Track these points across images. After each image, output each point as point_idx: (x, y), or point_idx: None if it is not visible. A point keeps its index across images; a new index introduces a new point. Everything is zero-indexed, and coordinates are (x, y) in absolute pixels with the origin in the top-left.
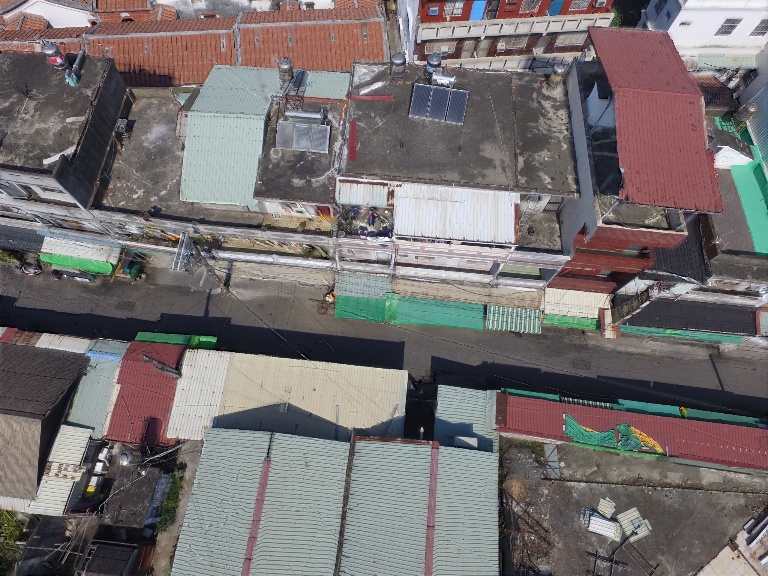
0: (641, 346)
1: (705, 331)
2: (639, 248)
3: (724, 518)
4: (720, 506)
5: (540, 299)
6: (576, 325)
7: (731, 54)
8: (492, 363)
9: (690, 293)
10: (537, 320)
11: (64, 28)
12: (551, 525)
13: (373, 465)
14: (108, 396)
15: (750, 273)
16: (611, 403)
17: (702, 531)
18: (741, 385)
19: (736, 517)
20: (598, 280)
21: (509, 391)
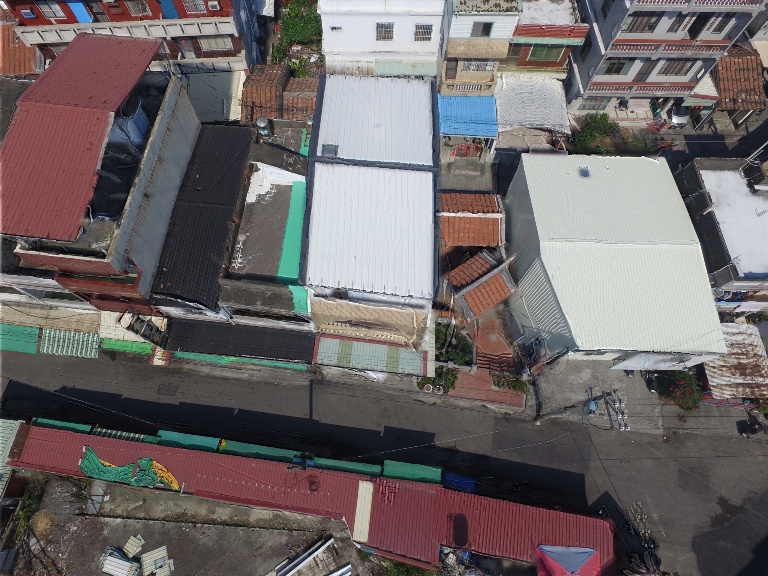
0: (234, 370)
1: (258, 358)
2: (99, 274)
3: (257, 558)
4: (258, 544)
5: (98, 322)
6: (114, 351)
7: (409, 60)
8: (72, 388)
9: (235, 318)
10: (95, 344)
11: None
12: (66, 565)
13: None
14: None
15: (261, 299)
16: (147, 434)
17: (227, 572)
18: (331, 413)
19: (271, 557)
20: (132, 304)
21: (40, 421)
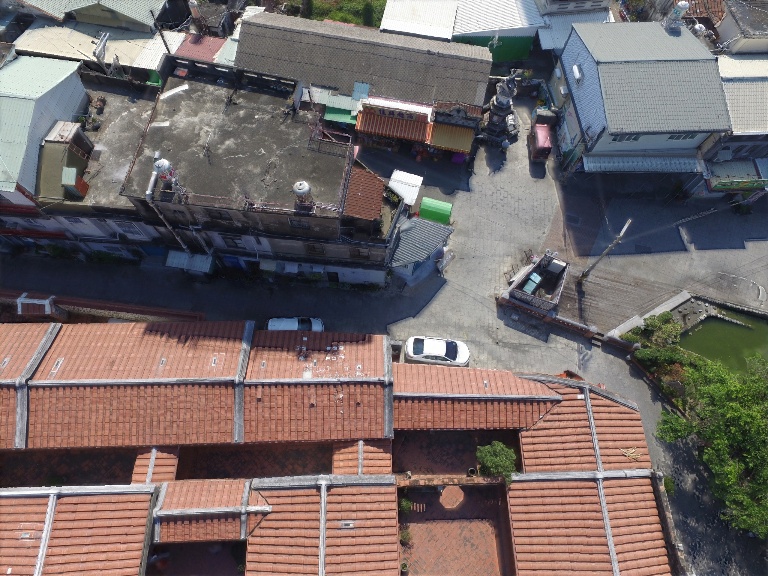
0: None
1: None
2: None
3: None
4: None
5: None
6: None
7: None
8: None
9: None
10: None
11: (291, 437)
12: None
13: (53, 3)
14: (222, 53)
15: None
16: None
17: None
18: None
19: None
20: None
21: None
